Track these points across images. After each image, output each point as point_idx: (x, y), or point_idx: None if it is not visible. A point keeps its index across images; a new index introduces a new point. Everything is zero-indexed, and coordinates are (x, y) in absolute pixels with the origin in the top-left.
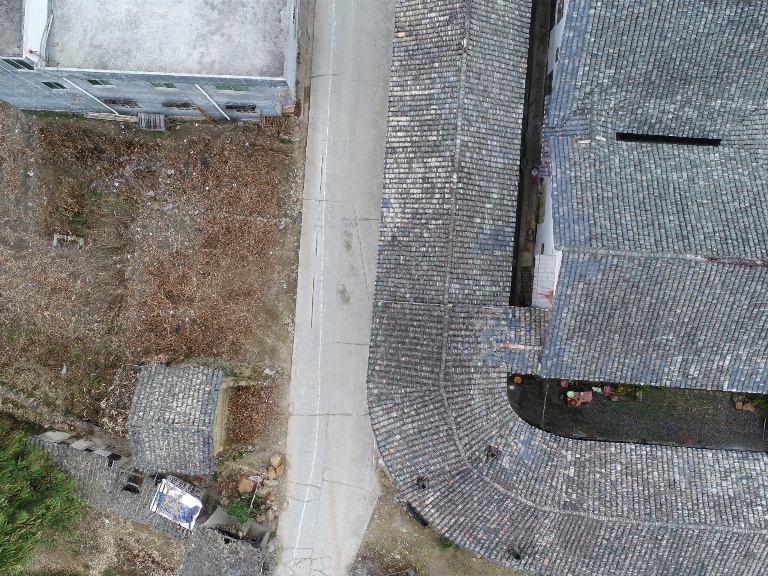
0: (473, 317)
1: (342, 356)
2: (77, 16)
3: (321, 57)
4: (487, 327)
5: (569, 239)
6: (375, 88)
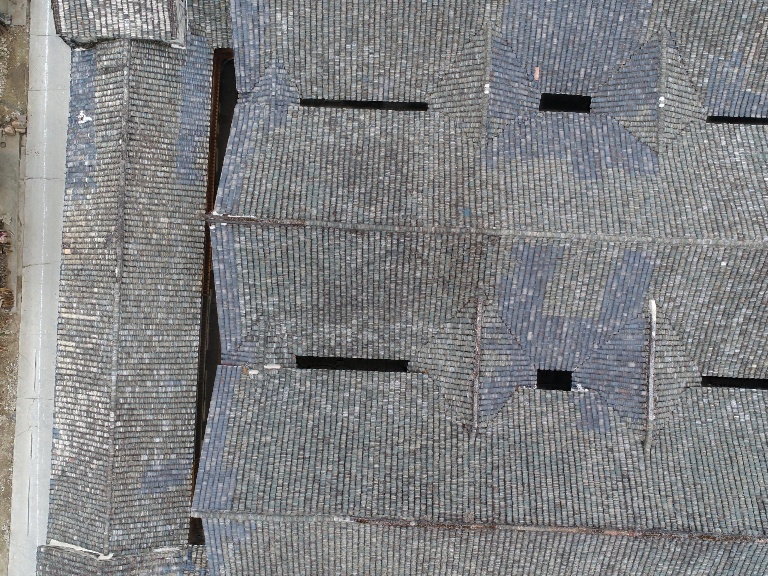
0: (136, 567)
1: None
2: None
3: (32, 245)
4: (154, 575)
5: (209, 501)
6: None
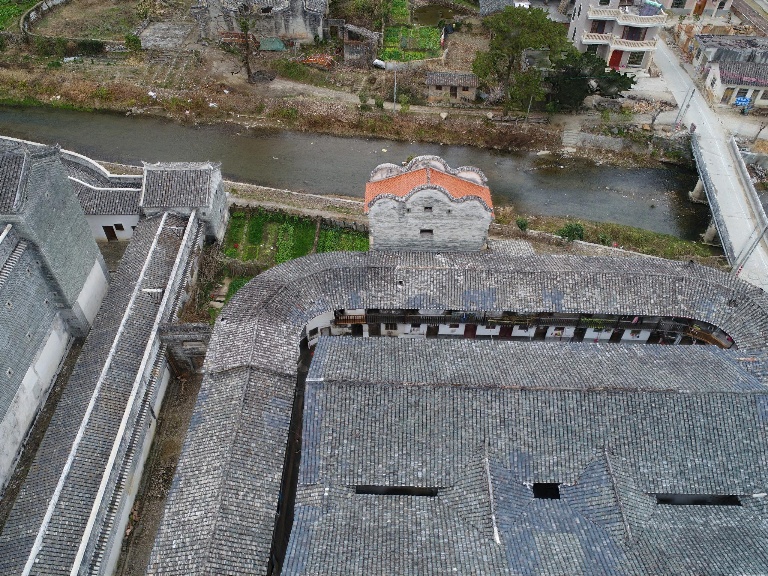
0: None
1: None
2: None
3: None
4: None
5: None
6: None
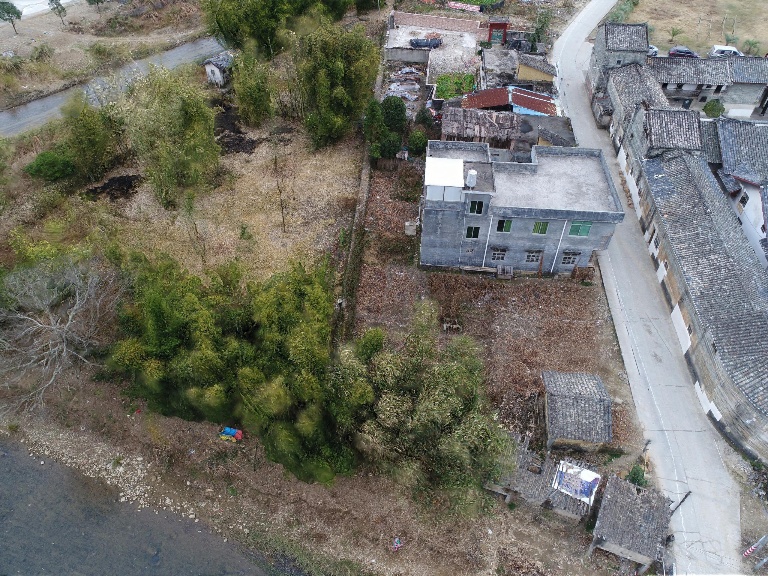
0: None
1: (669, 393)
2: (501, 195)
3: None
4: None
5: None
6: (637, 261)
